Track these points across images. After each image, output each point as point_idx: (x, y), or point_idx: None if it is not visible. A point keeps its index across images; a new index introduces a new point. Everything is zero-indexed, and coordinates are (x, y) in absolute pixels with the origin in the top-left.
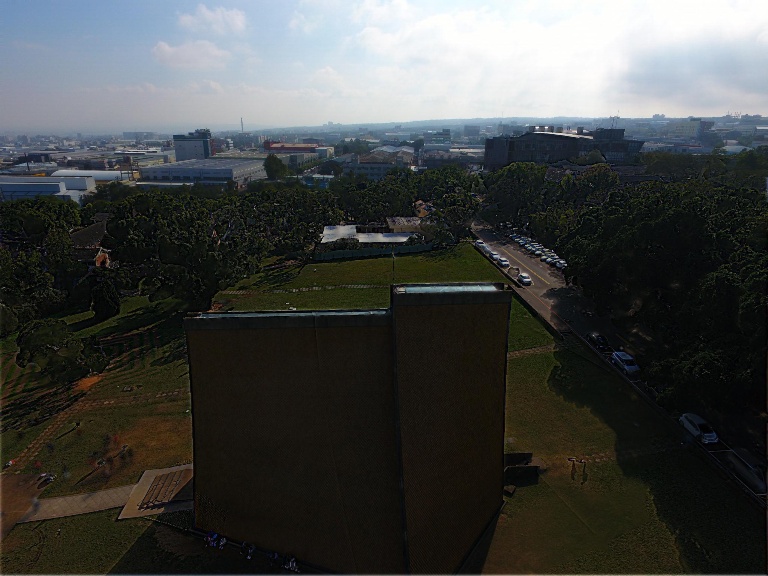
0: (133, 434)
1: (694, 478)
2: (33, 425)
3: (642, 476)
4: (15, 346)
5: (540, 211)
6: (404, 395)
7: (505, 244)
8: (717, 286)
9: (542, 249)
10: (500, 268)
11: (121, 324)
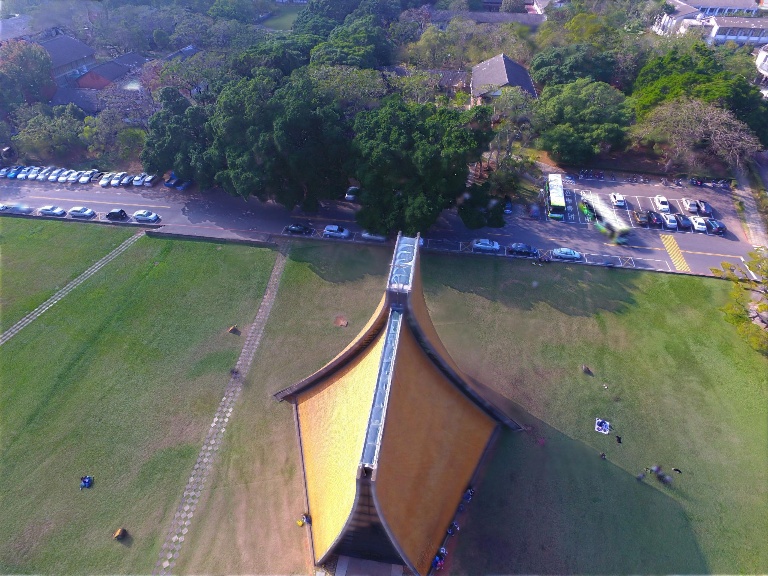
0: None
1: (443, 264)
2: None
3: (433, 282)
4: None
5: (8, 127)
6: (435, 347)
7: (16, 189)
8: (384, 154)
9: (81, 174)
10: (92, 220)
11: None
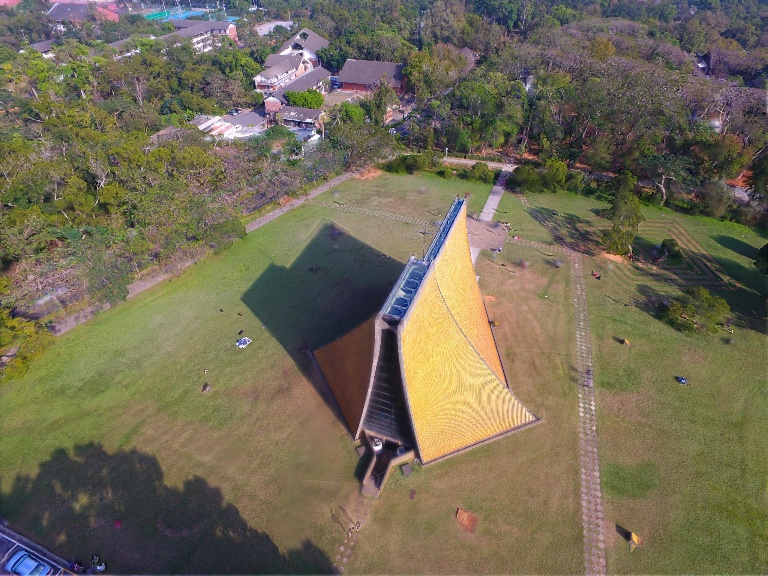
0: (528, 275)
1: None
2: (555, 240)
3: (300, 568)
4: (690, 223)
5: None
6: None
7: None
8: None
9: None
10: None
11: (747, 269)
